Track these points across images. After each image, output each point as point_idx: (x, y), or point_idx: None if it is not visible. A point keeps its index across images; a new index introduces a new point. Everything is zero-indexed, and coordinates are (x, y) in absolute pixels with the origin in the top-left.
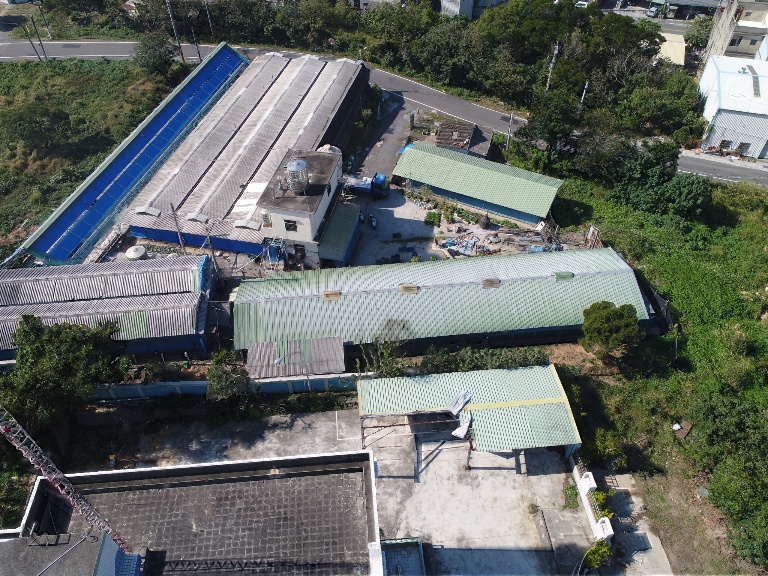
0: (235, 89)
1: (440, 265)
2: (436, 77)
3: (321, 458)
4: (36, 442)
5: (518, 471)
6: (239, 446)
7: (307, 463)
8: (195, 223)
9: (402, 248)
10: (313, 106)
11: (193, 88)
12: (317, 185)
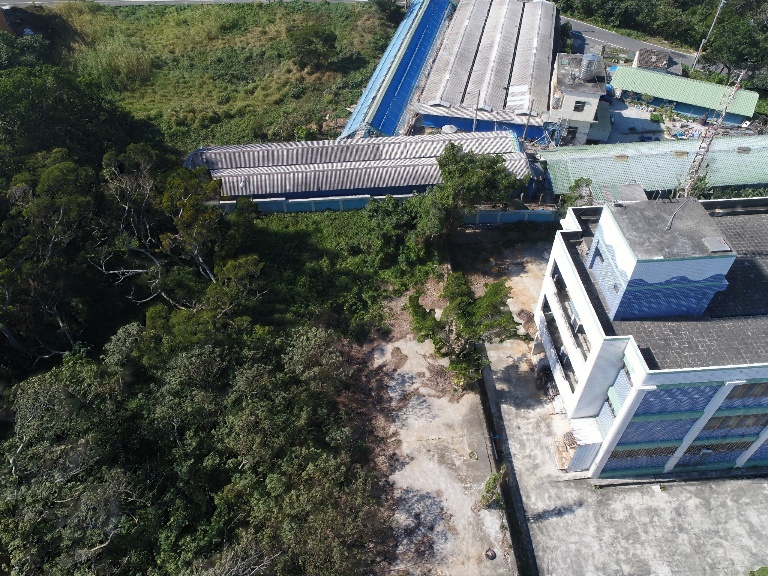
0: (458, 21)
1: (691, 142)
2: (605, 21)
3: (752, 201)
4: (443, 243)
5: None
6: None
7: (740, 206)
8: (482, 112)
9: (642, 137)
10: (533, 33)
11: (426, 19)
12: (597, 76)
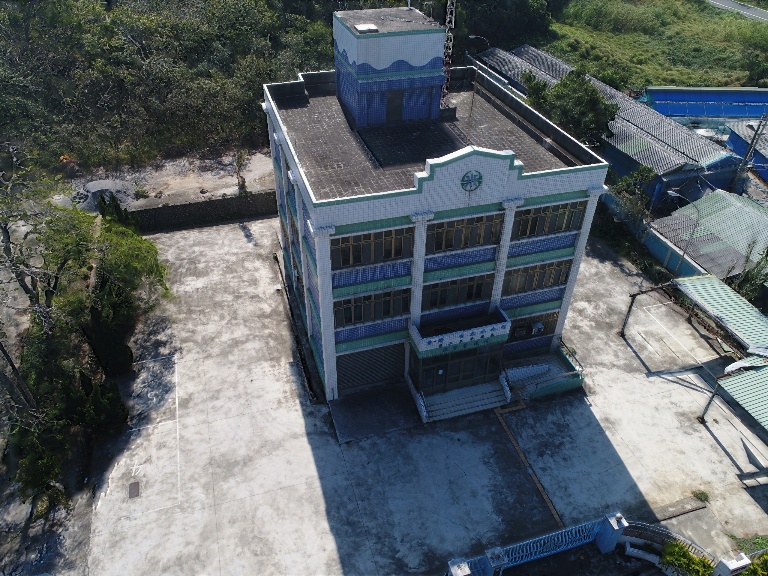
0: None
1: None
2: None
3: (577, 147)
4: None
5: (742, 476)
6: (586, 250)
7: (568, 148)
8: None
9: None
10: None
11: None
12: None
